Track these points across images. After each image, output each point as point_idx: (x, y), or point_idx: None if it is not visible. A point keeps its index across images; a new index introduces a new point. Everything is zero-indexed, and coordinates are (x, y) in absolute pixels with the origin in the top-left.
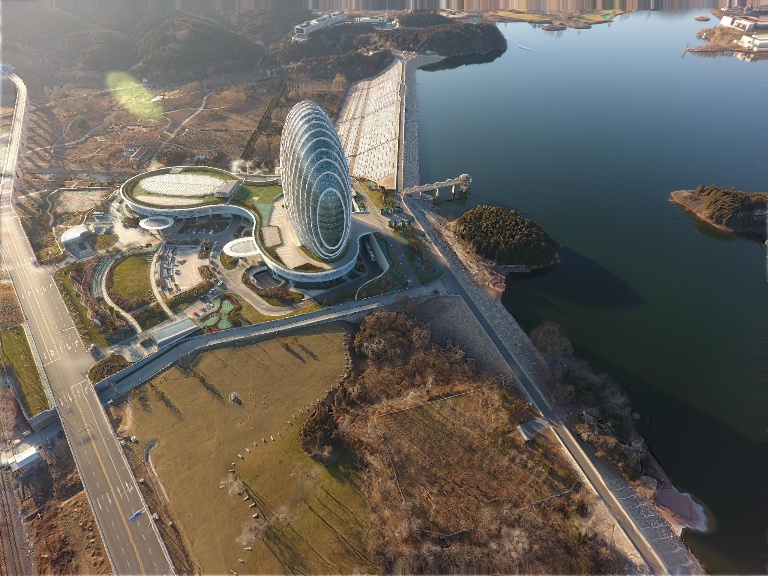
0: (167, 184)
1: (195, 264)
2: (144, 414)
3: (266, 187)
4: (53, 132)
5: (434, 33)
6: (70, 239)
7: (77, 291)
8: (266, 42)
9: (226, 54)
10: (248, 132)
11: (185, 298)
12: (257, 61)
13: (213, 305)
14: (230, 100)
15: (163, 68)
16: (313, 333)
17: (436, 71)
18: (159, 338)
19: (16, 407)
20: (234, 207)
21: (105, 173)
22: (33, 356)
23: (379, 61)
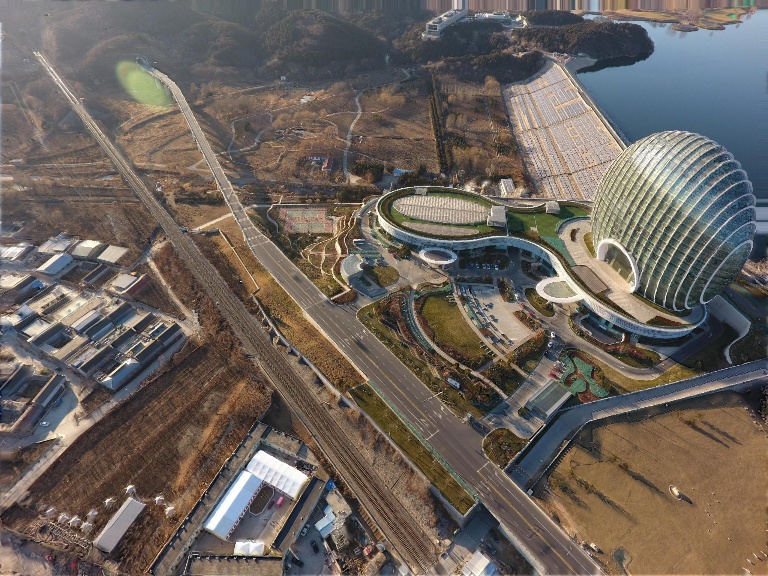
0: (425, 208)
1: (507, 308)
2: (583, 511)
3: (535, 215)
4: (220, 135)
5: (584, 34)
6: (354, 273)
7: (400, 340)
8: (386, 37)
9: (362, 51)
10: (427, 141)
11: (528, 354)
12: (385, 58)
13: (564, 364)
14: (386, 103)
15: (302, 65)
16: (709, 406)
17: (578, 74)
18: (544, 409)
19: (430, 497)
20: (518, 239)
21: (302, 185)
22: (407, 427)
23: (532, 63)
